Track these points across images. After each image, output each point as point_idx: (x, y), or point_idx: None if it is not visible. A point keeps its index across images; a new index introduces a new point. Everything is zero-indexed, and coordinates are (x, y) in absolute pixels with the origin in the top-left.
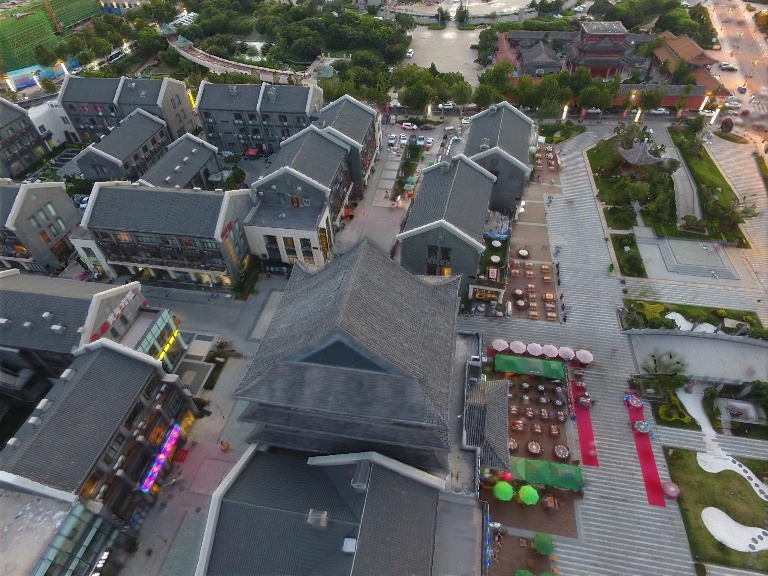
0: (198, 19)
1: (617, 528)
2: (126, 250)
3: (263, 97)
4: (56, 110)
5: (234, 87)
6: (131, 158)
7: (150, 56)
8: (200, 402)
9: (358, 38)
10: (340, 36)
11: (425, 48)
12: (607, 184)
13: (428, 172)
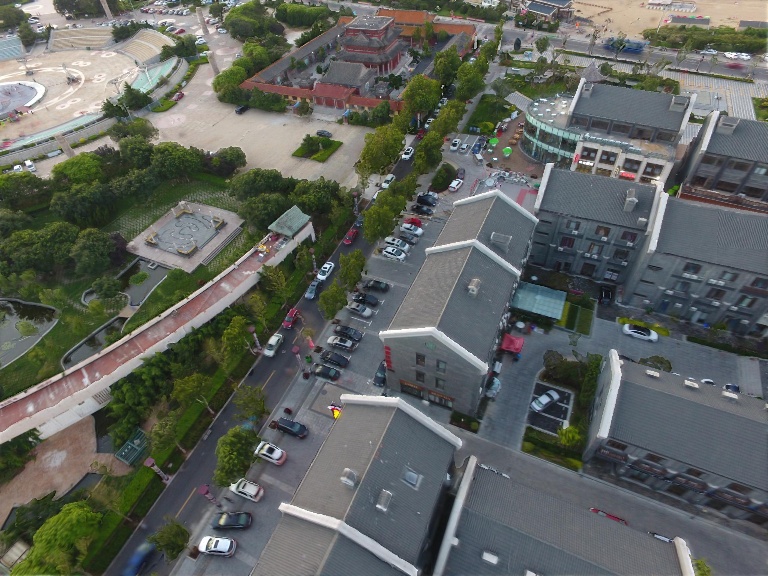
0: None
1: None
2: None
3: None
4: None
5: (479, 281)
6: None
7: None
8: None
9: (150, 180)
10: (94, 203)
11: (200, 144)
12: None
13: (709, 147)
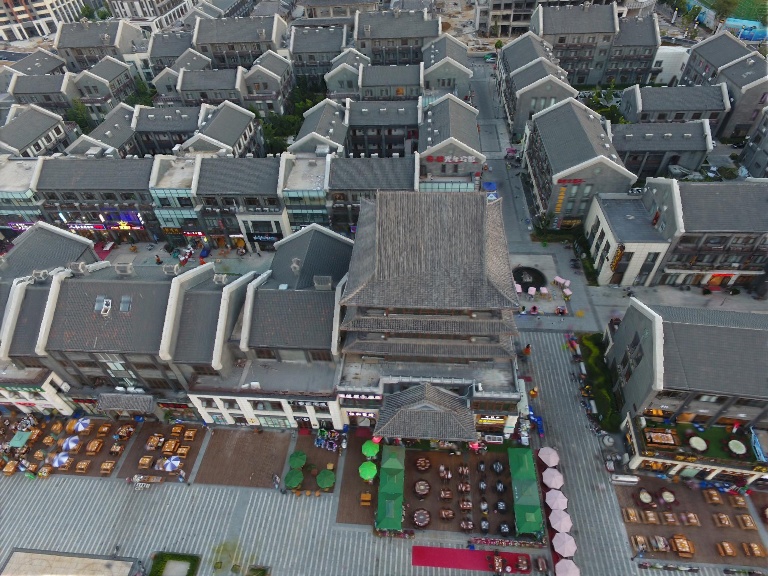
0: None
1: (347, 569)
2: None
3: None
4: (685, 55)
5: None
6: (656, 114)
7: None
8: None
9: None
10: None
11: None
12: None
13: None
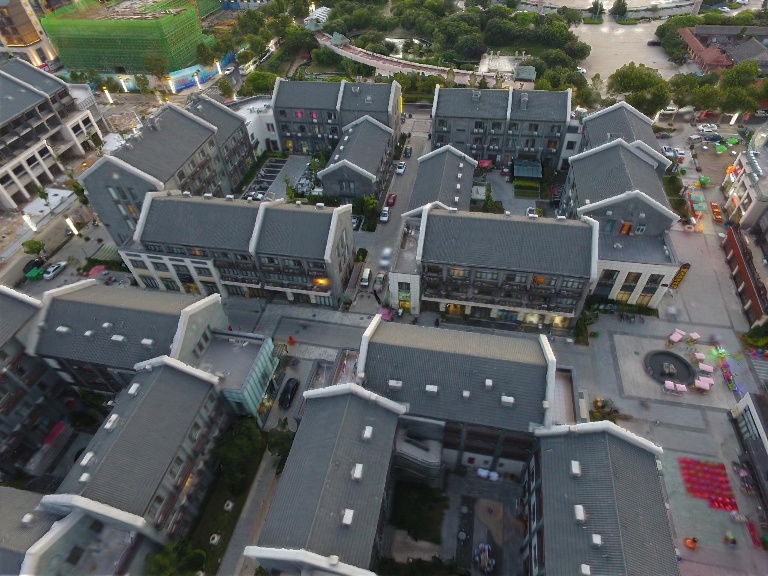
0: (333, 14)
1: None
2: (449, 286)
3: (512, 103)
4: (264, 116)
5: (479, 92)
6: None
7: (295, 54)
8: None
9: (529, 34)
10: (502, 32)
11: (595, 45)
12: None
13: None
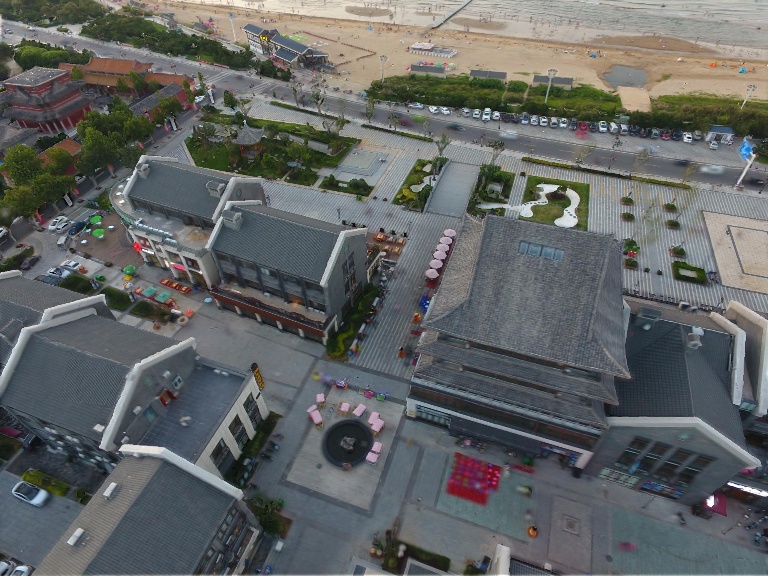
0: None
1: None
2: None
3: None
4: None
5: None
6: None
7: None
8: (473, 572)
9: None
10: None
11: None
12: (255, 170)
13: (216, 244)
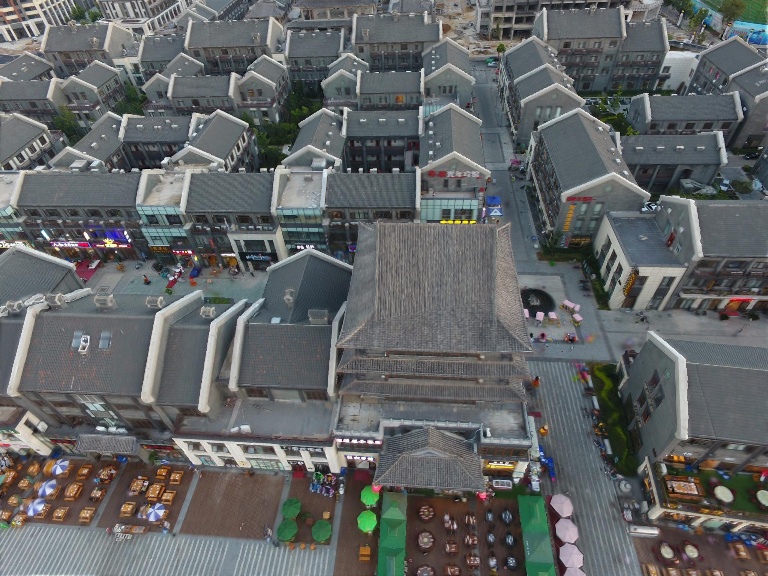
0: None
1: None
2: None
3: None
4: (694, 61)
5: None
6: (666, 123)
7: None
8: None
9: None
10: None
11: None
12: None
13: None
